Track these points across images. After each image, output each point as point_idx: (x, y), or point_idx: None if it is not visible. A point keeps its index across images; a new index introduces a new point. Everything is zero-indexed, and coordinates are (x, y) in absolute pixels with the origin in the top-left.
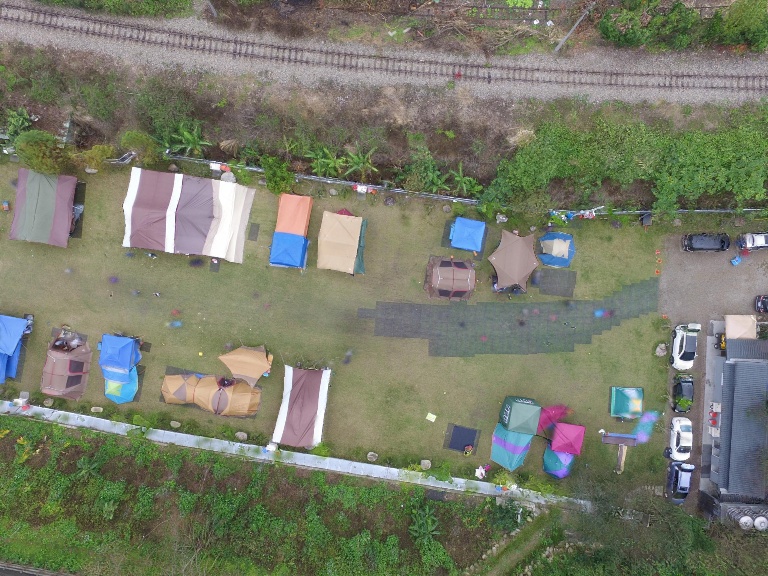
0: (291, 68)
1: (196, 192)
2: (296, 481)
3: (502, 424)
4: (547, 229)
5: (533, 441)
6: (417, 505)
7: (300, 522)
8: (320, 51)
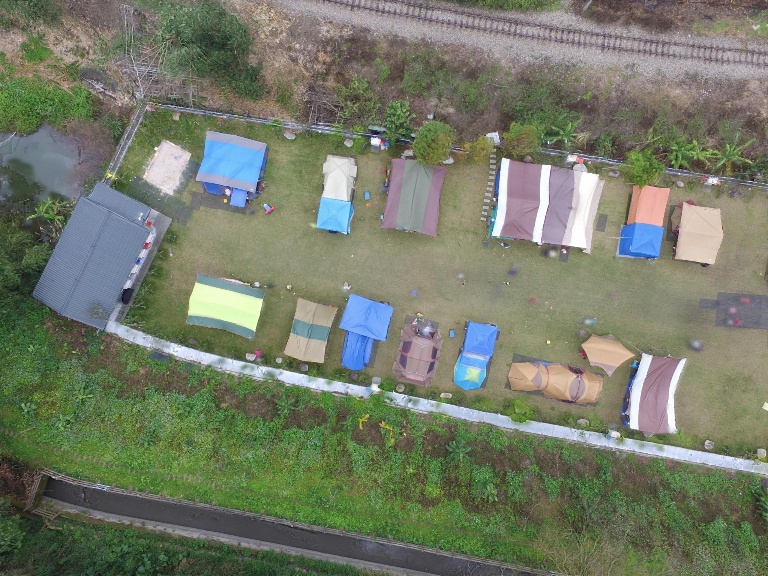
0: (658, 61)
1: (561, 183)
2: (640, 468)
3: None
4: None
5: None
6: (762, 493)
7: (658, 507)
8: (687, 44)
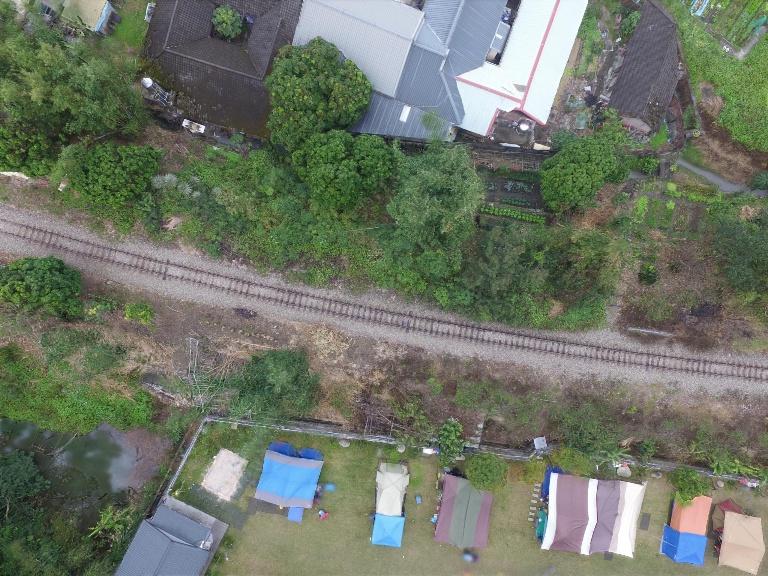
0: (700, 379)
1: (608, 495)
2: None
3: None
4: None
5: None
6: None
7: None
8: (728, 364)
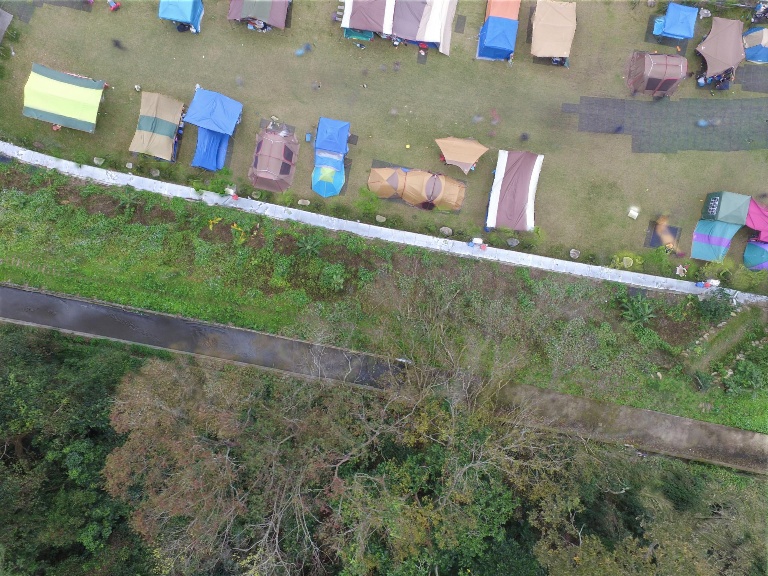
0: None
1: None
2: (503, 274)
3: (707, 219)
4: (749, 25)
5: (733, 240)
6: (625, 296)
7: (516, 306)
8: None
